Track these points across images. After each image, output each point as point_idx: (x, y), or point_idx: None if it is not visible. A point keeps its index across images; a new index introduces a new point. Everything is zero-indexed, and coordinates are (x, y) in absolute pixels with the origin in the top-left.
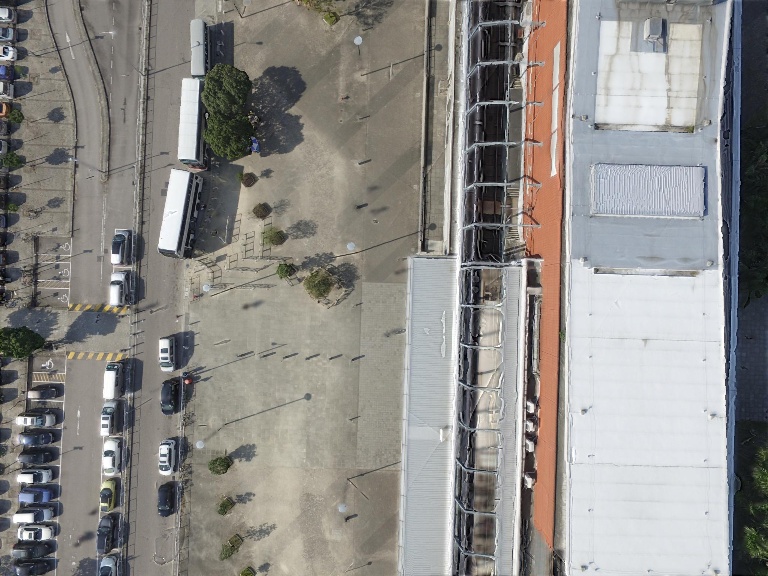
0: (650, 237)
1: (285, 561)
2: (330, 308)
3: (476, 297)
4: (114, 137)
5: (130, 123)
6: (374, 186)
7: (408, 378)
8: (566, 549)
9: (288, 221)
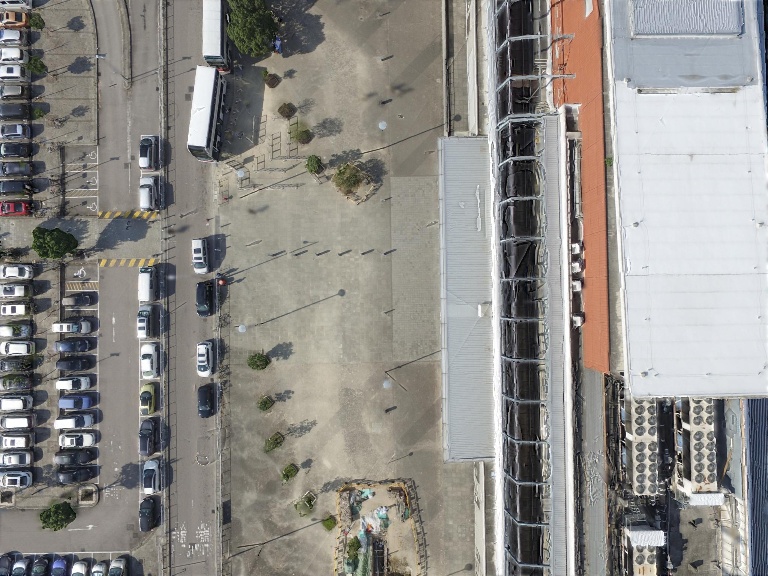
0: (691, 56)
1: (327, 456)
2: (360, 204)
3: None
4: (135, 44)
5: (151, 29)
6: (397, 81)
7: (444, 257)
8: (624, 361)
9: (313, 120)
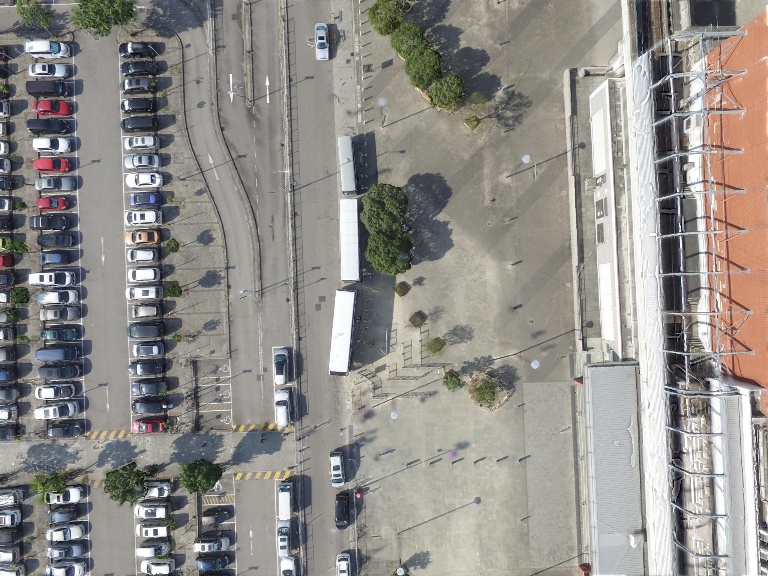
0: None
1: None
2: (493, 411)
3: (676, 415)
4: (264, 255)
5: (279, 240)
6: (527, 287)
7: (594, 486)
8: None
9: (444, 327)
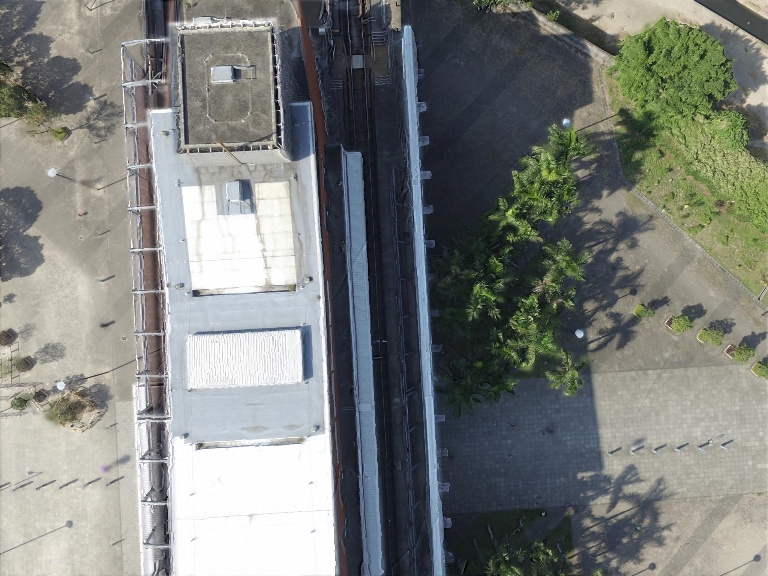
0: (253, 406)
1: None
2: (85, 431)
3: None
4: None
5: None
6: (120, 302)
7: (140, 511)
8: None
9: (35, 345)
